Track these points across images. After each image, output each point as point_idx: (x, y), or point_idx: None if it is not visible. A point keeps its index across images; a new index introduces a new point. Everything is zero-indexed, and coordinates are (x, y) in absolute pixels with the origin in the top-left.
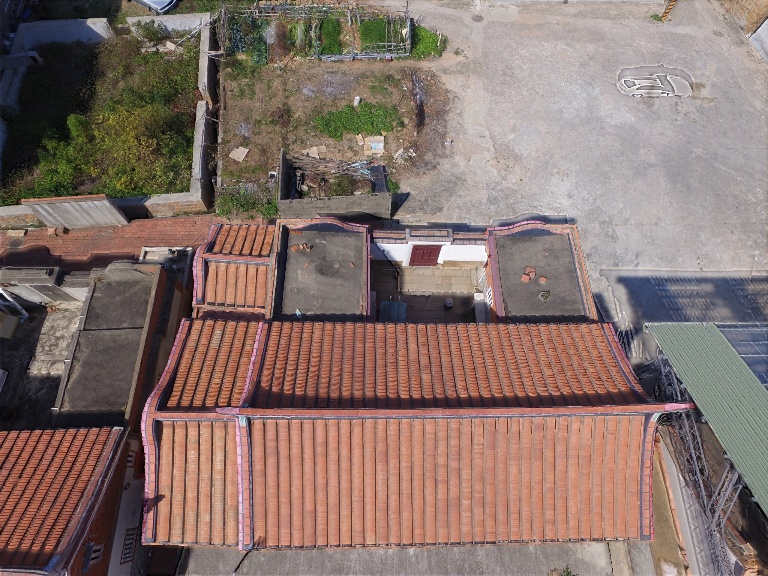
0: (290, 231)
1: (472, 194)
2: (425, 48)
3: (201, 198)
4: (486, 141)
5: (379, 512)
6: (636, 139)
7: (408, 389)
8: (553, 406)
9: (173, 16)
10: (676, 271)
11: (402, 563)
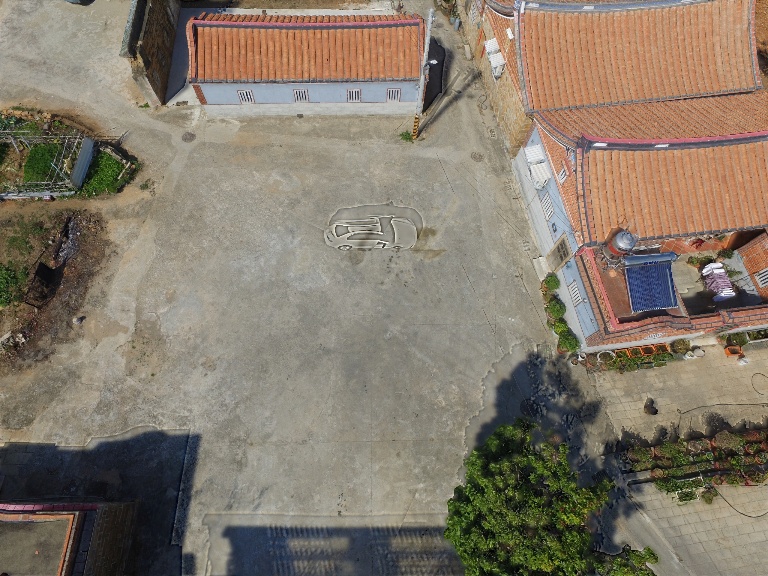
0: None
1: (80, 398)
2: (97, 184)
3: None
4: (128, 317)
5: None
6: (321, 312)
7: None
8: None
9: None
10: (305, 516)
11: None
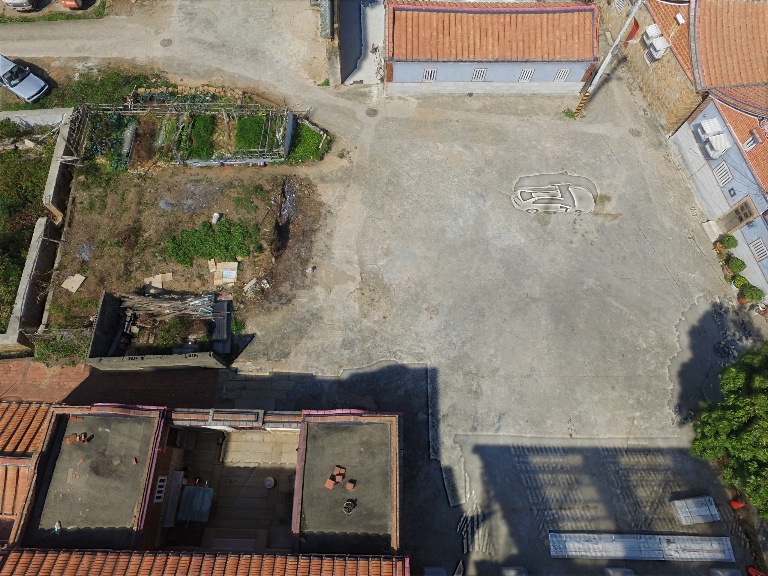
0: (70, 416)
1: (325, 336)
2: (303, 152)
3: (17, 341)
4: (353, 268)
5: None
6: (522, 266)
7: None
8: None
9: (33, 112)
10: (541, 438)
11: None
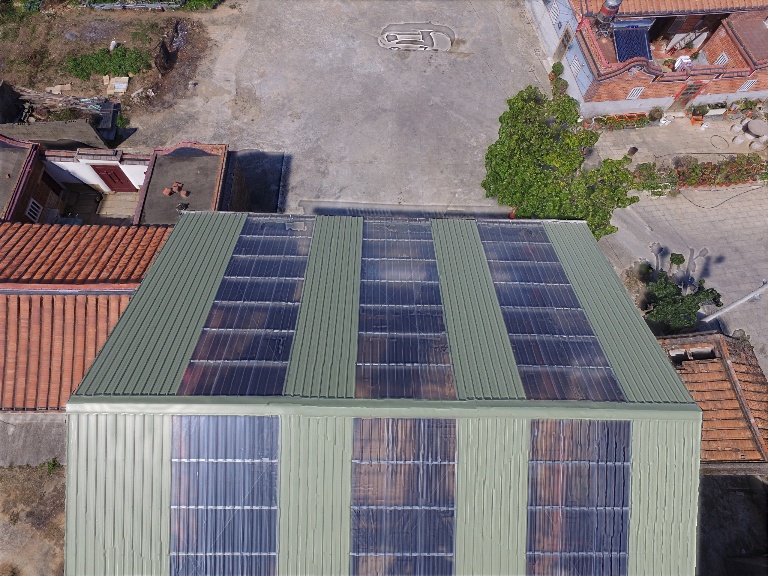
0: None
1: (199, 131)
2: (198, 0)
3: None
4: (230, 85)
5: None
6: (378, 87)
7: None
8: None
9: None
10: (374, 204)
11: None
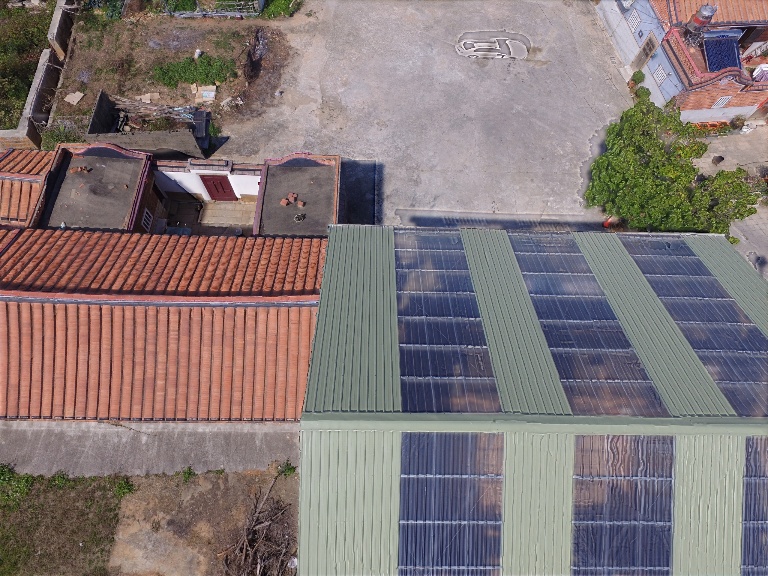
0: (73, 155)
1: (290, 139)
2: (275, 8)
3: (26, 135)
4: (315, 93)
5: (79, 389)
6: (461, 95)
7: (122, 283)
8: (238, 296)
9: None
10: (469, 213)
11: (132, 450)
